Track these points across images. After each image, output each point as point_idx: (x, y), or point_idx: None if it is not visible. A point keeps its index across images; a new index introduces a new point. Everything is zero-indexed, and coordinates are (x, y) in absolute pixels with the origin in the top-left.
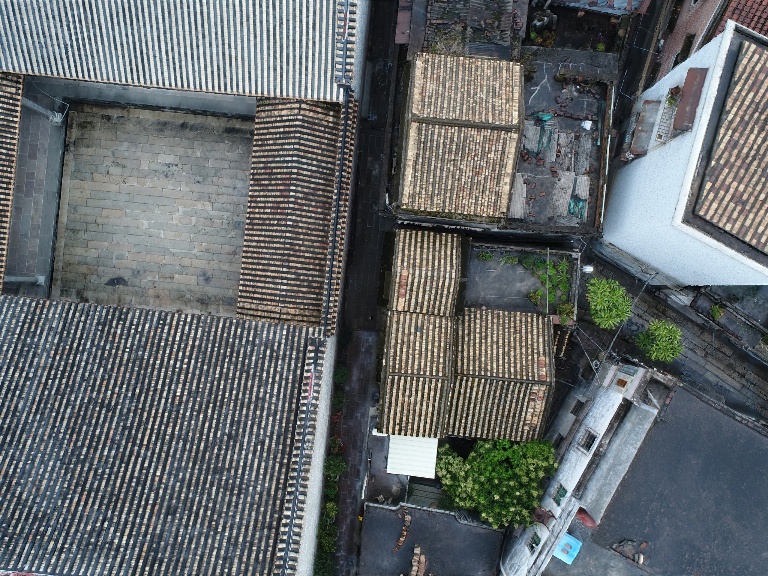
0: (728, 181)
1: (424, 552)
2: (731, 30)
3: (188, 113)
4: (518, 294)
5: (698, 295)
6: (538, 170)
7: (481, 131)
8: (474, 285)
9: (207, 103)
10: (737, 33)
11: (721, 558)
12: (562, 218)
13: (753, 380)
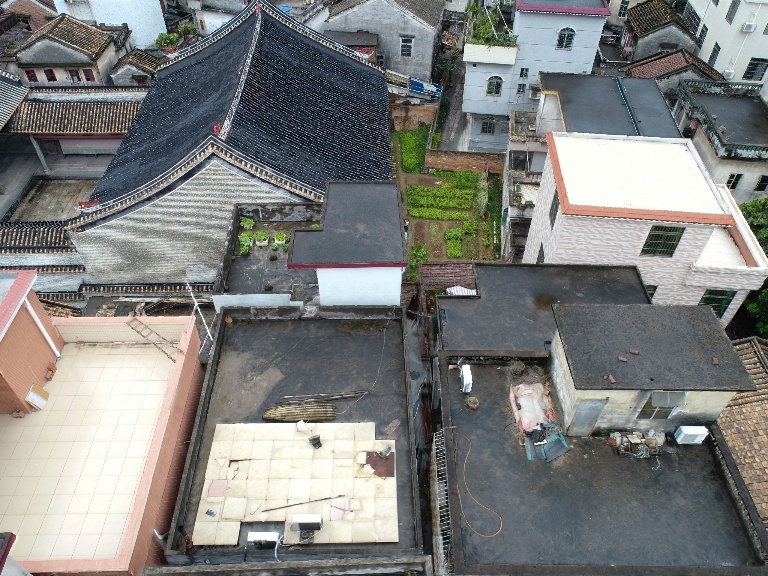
0: None
1: None
2: None
3: None
4: None
5: (172, 30)
6: None
7: None
8: None
9: (5, 206)
10: None
11: None
12: None
13: None
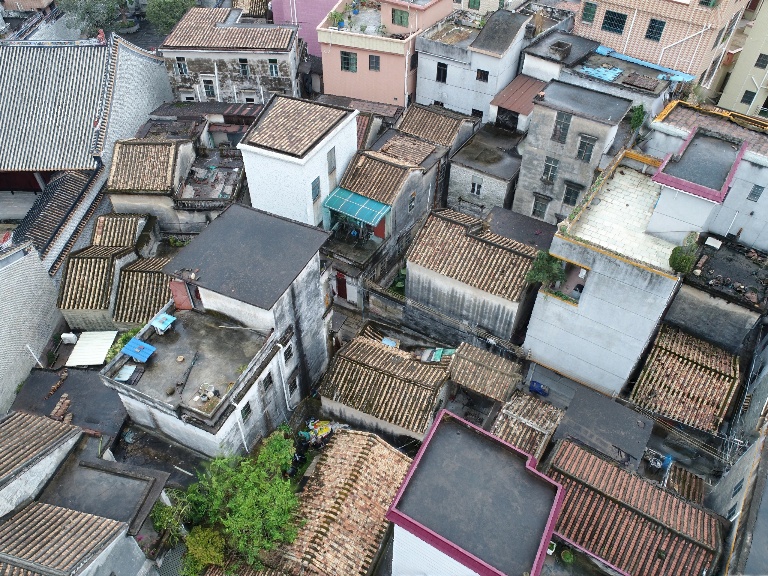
0: None
1: (71, 398)
2: None
3: (15, 224)
4: None
5: None
6: (204, 186)
7: (156, 147)
8: None
9: None
10: None
11: (251, 275)
12: (214, 202)
13: None
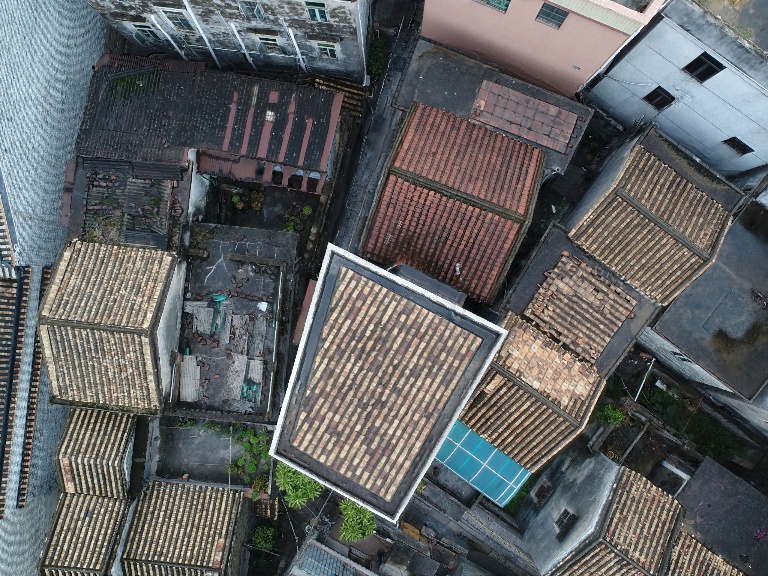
0: (323, 411)
1: None
2: (328, 255)
3: None
4: (222, 461)
5: None
6: (213, 351)
7: (114, 333)
8: (177, 452)
9: None
10: (337, 257)
11: None
12: (236, 401)
13: (497, 531)
